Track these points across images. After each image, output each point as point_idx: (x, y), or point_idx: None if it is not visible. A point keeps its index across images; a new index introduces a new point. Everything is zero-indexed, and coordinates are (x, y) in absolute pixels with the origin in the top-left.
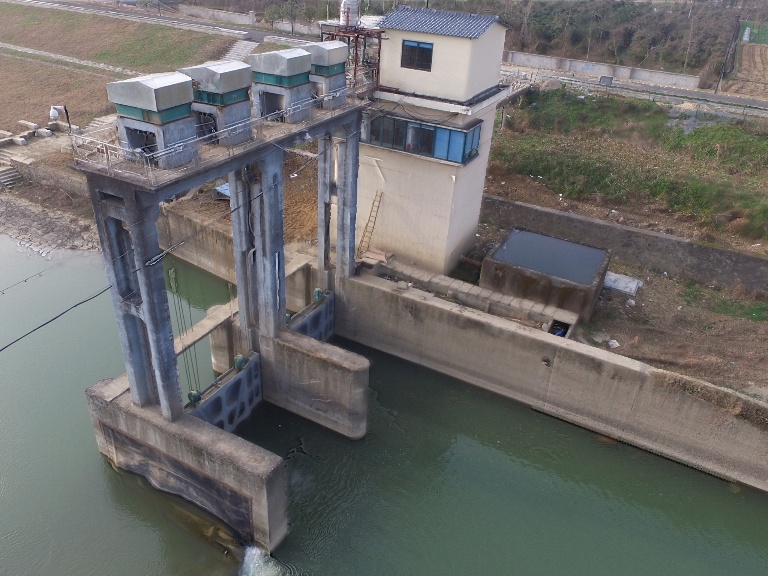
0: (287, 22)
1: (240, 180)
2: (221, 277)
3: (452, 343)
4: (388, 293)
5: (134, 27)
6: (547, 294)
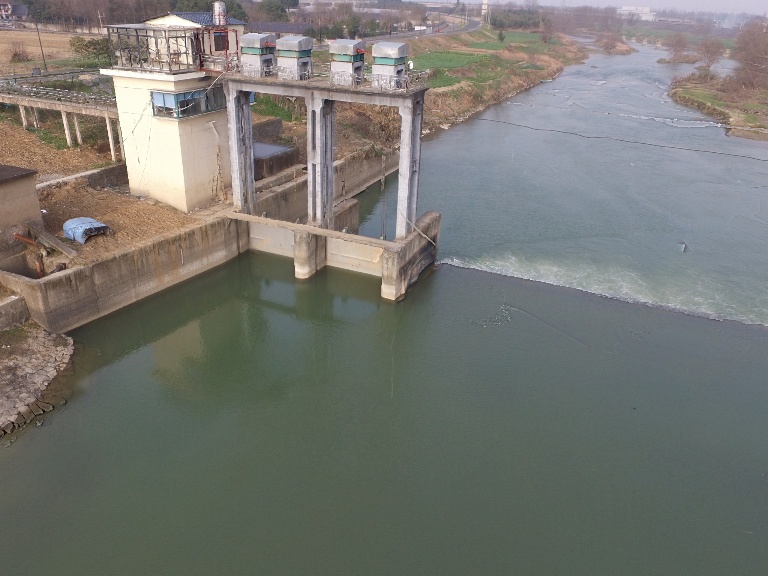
0: None
1: (323, 117)
2: (166, 288)
3: None
4: (274, 195)
5: None
6: None
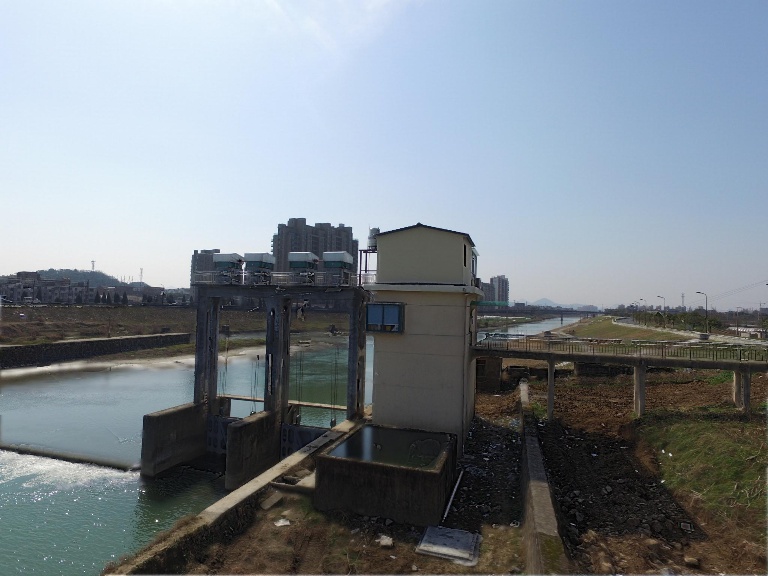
0: None
1: None
2: None
3: None
4: None
5: None
6: None
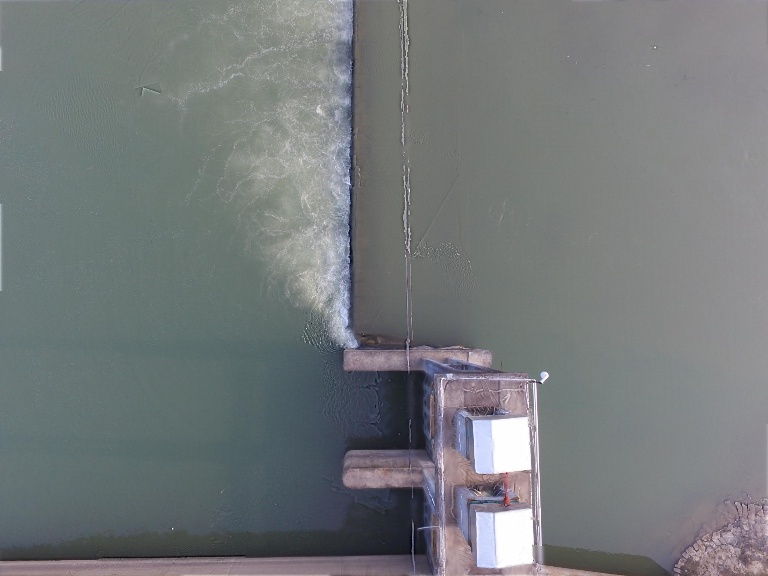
0: None
1: None
2: (566, 568)
3: (314, 574)
4: None
5: None
6: None
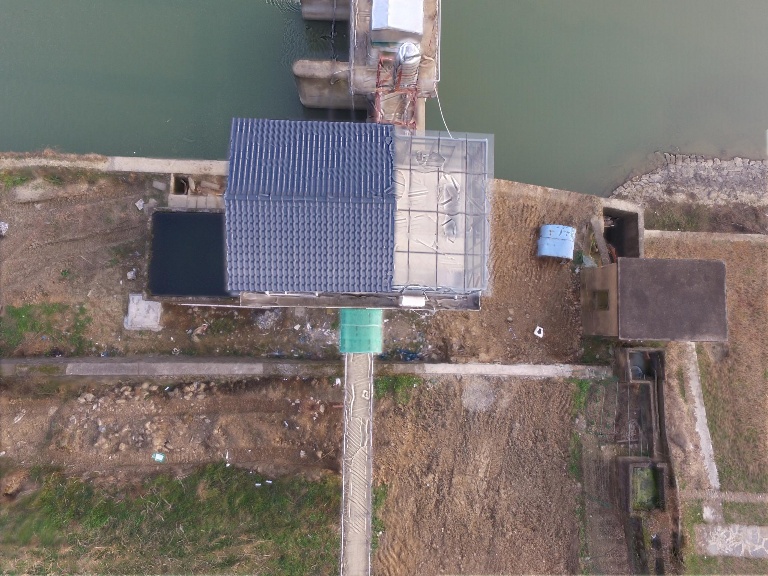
0: None
1: None
2: None
3: None
4: None
5: None
6: None
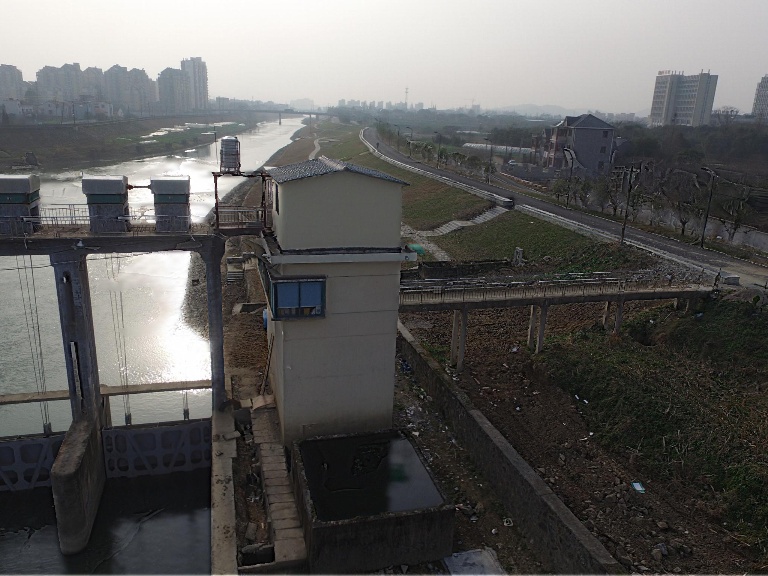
0: (572, 196)
1: None
2: None
3: None
4: None
5: (444, 189)
6: (302, 512)
